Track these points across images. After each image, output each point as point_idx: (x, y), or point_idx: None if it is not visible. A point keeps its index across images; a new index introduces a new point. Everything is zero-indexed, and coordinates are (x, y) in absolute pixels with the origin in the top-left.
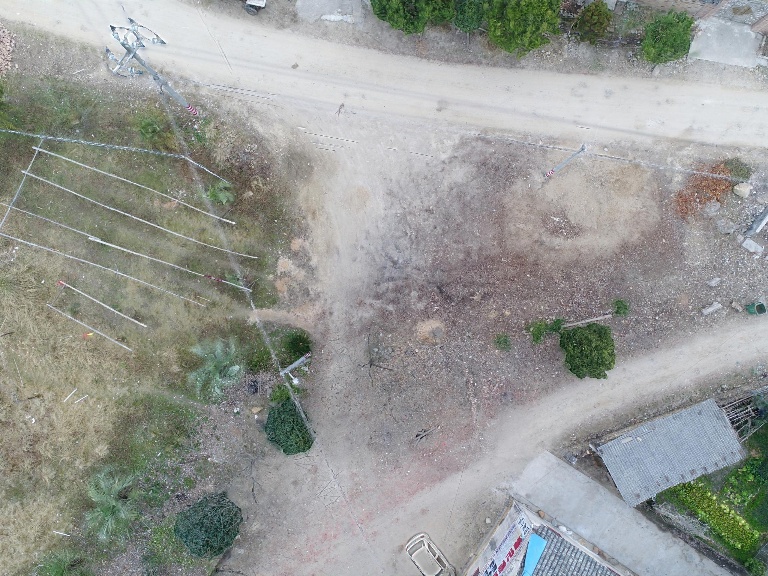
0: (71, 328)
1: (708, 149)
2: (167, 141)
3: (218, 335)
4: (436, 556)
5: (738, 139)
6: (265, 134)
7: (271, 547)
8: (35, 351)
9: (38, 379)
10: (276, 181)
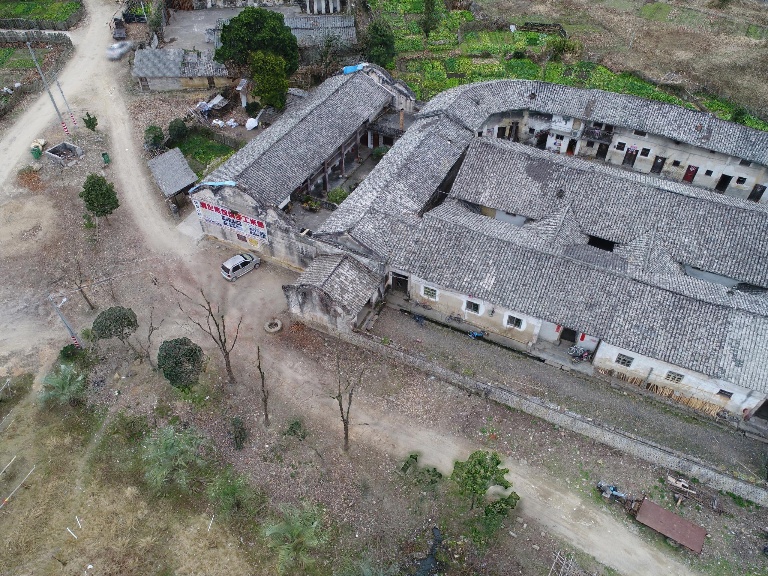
0: (1, 540)
1: (8, 181)
2: None
3: (47, 411)
4: None
5: (7, 171)
6: None
7: (230, 356)
8: (15, 575)
9: (47, 570)
10: None
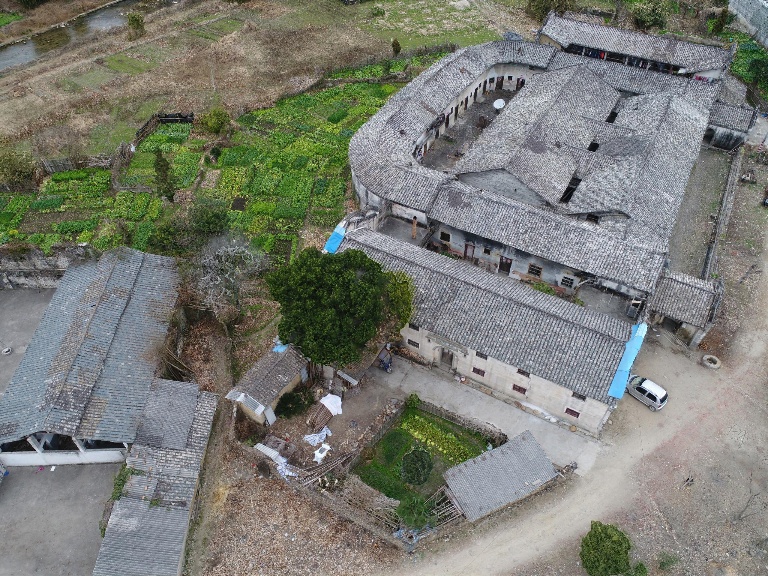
0: None
1: None
2: None
3: None
4: (647, 394)
5: None
6: None
7: (760, 395)
8: None
9: None
10: None
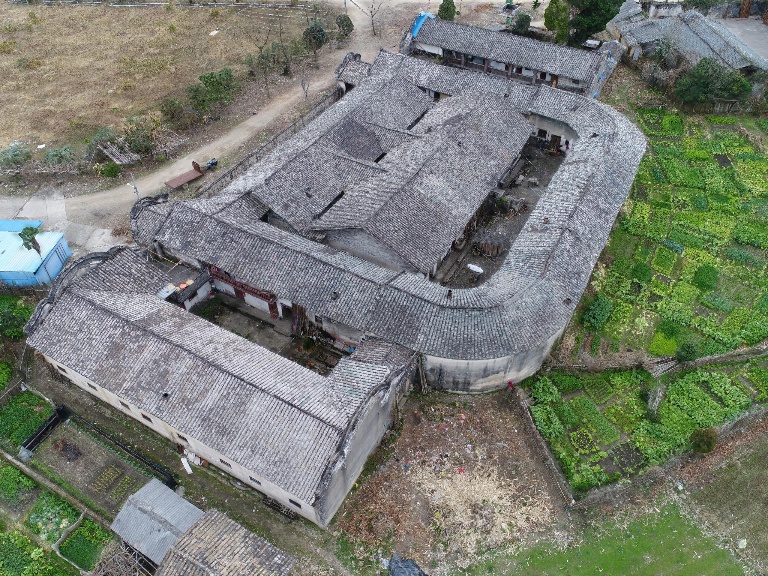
0: None
1: None
2: (297, 3)
3: None
4: None
5: None
6: (331, 5)
7: None
8: None
9: None
10: (335, 11)
